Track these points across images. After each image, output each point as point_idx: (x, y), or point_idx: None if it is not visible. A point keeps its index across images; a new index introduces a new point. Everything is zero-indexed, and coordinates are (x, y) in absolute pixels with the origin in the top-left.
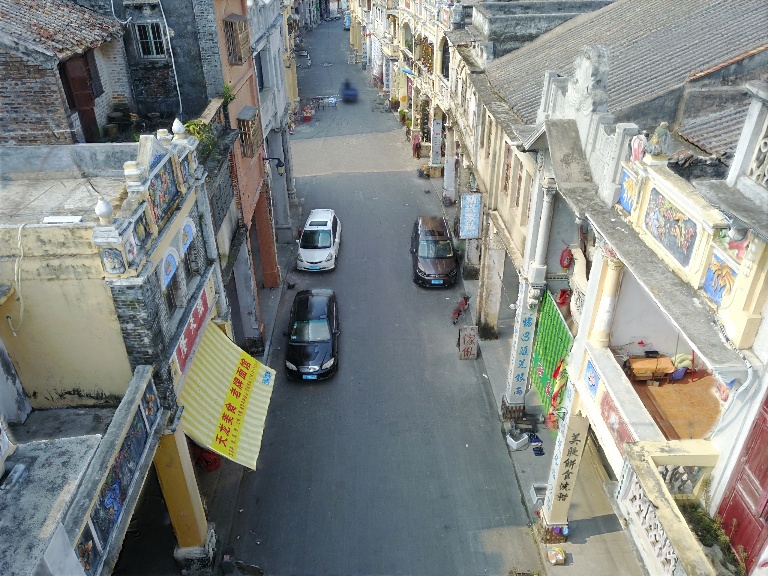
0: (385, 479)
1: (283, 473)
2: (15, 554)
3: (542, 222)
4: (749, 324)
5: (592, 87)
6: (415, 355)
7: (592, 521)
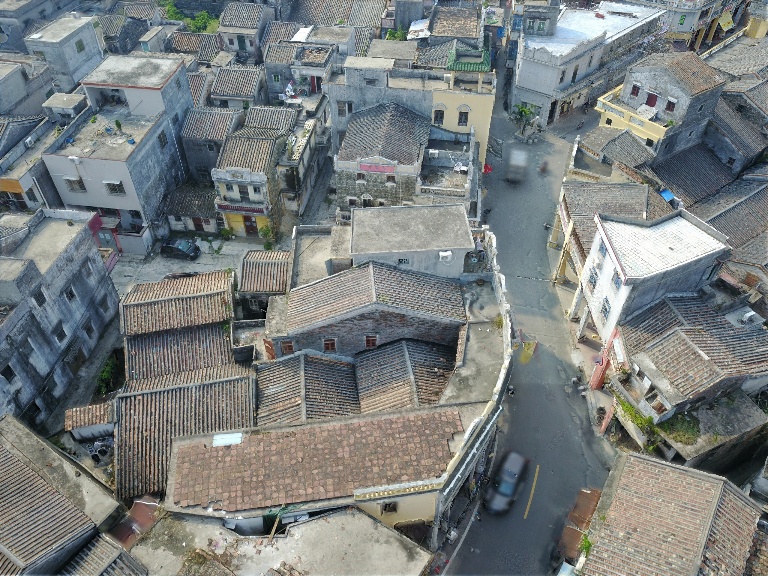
0: None
1: None
2: None
3: None
4: None
5: None
6: None
7: None
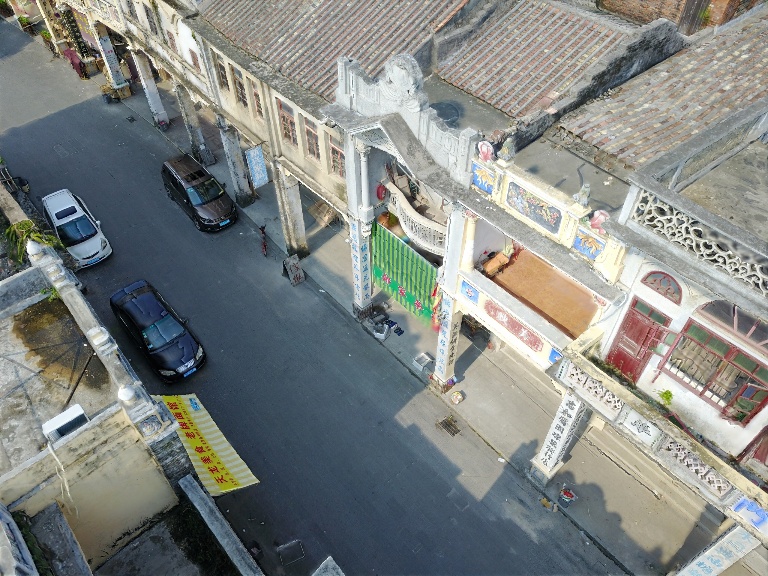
0: (314, 417)
1: None
2: None
3: (364, 177)
4: (619, 272)
5: (414, 92)
6: (256, 302)
7: (460, 361)
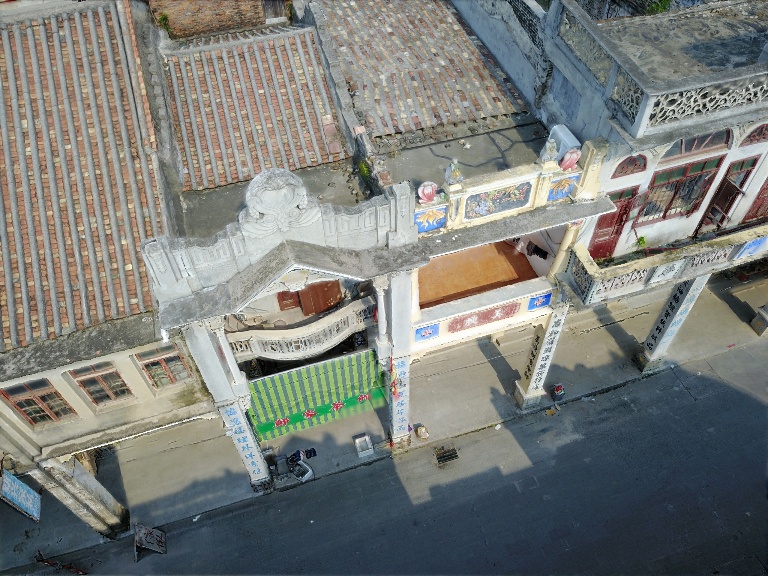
0: None
1: None
2: None
3: (229, 350)
4: None
5: (307, 202)
6: None
7: (379, 411)
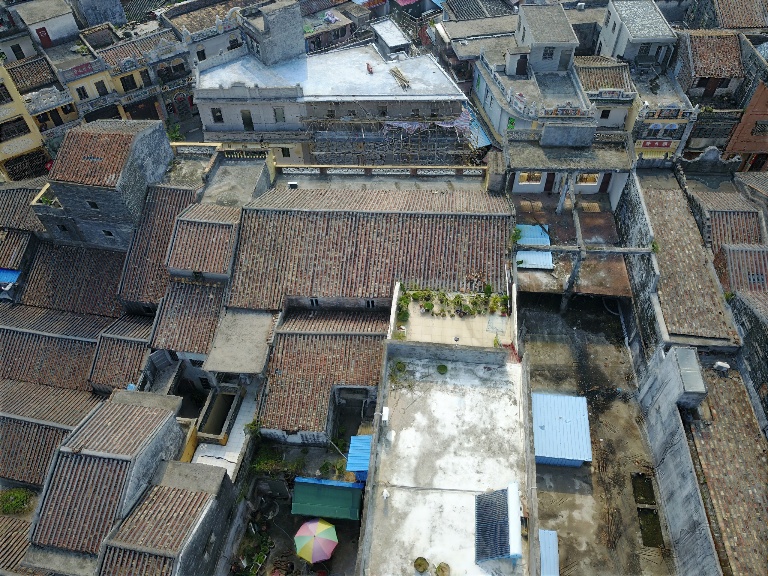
0: None
1: None
2: (580, 121)
3: None
4: None
5: None
6: None
7: None
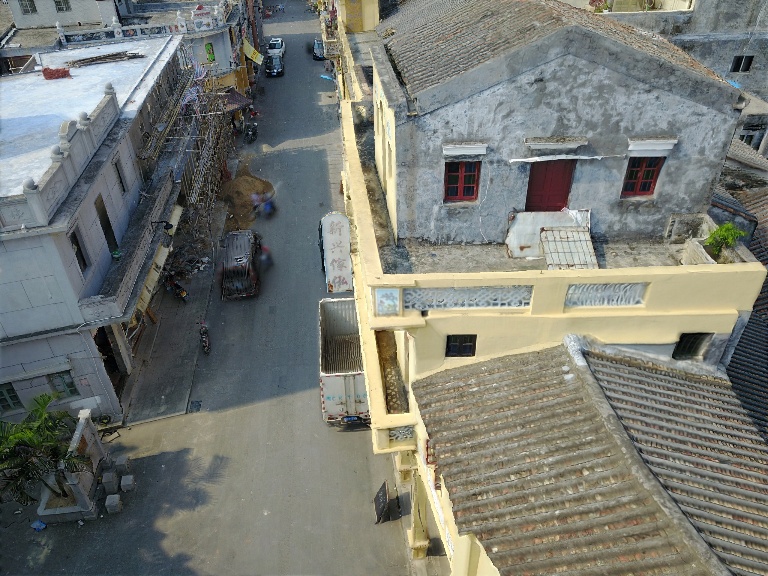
0: None
1: (267, 89)
2: None
3: None
4: None
5: None
6: (310, 72)
7: None
